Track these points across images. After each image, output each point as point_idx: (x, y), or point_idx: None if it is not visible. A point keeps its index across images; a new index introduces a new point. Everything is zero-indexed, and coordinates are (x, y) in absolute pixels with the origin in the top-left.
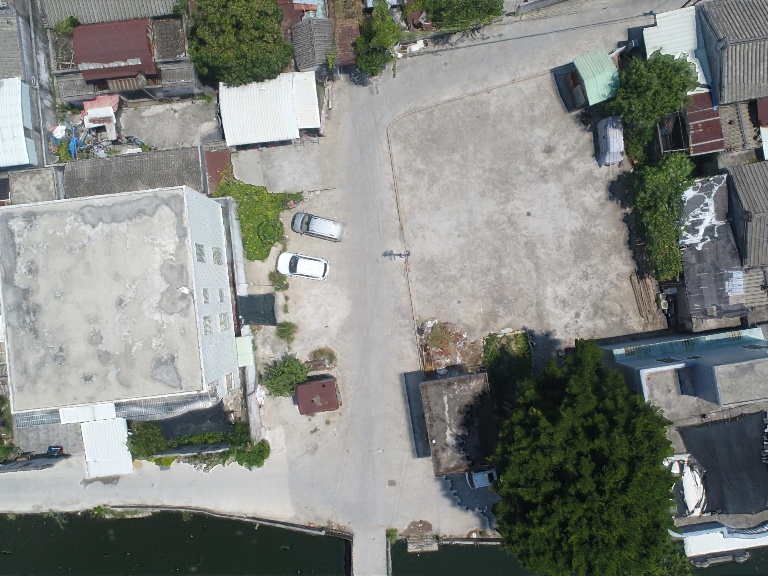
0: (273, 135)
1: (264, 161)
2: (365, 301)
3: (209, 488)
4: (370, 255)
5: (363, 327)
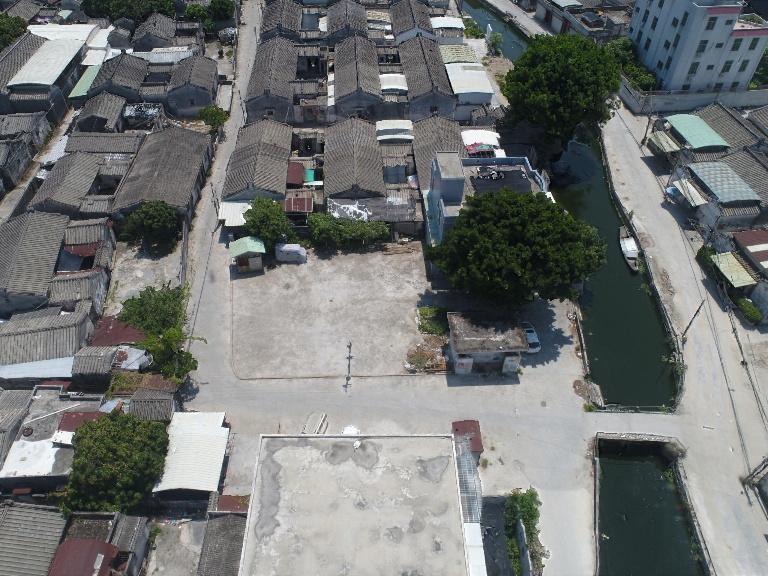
0: (220, 449)
1: (237, 483)
2: (384, 409)
3: (570, 574)
4: (344, 401)
5: (406, 413)
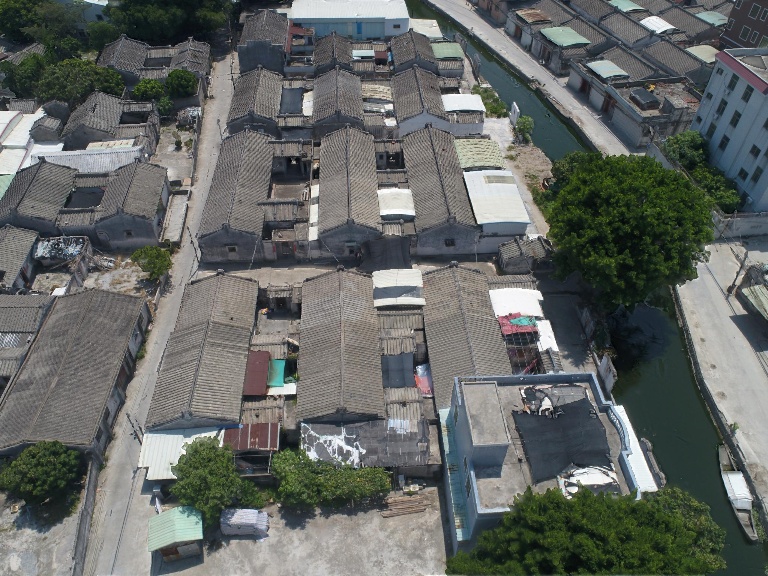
0: None
1: None
2: None
3: None
4: None
5: None
